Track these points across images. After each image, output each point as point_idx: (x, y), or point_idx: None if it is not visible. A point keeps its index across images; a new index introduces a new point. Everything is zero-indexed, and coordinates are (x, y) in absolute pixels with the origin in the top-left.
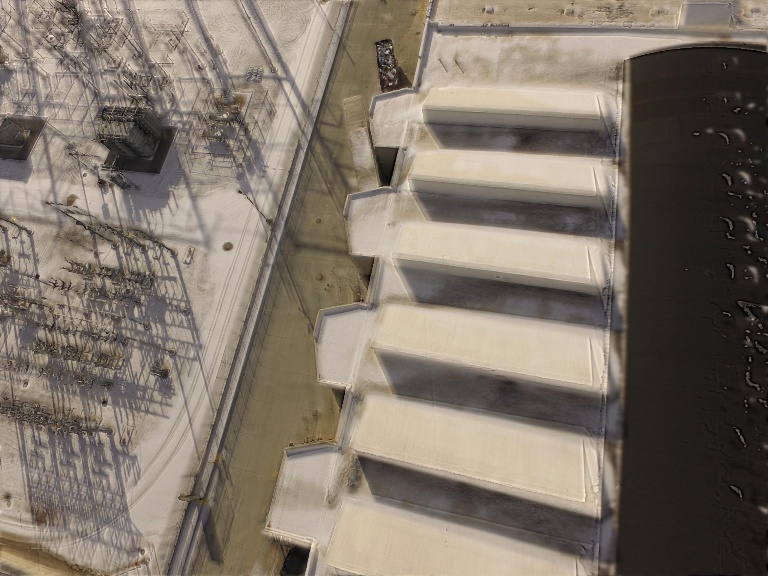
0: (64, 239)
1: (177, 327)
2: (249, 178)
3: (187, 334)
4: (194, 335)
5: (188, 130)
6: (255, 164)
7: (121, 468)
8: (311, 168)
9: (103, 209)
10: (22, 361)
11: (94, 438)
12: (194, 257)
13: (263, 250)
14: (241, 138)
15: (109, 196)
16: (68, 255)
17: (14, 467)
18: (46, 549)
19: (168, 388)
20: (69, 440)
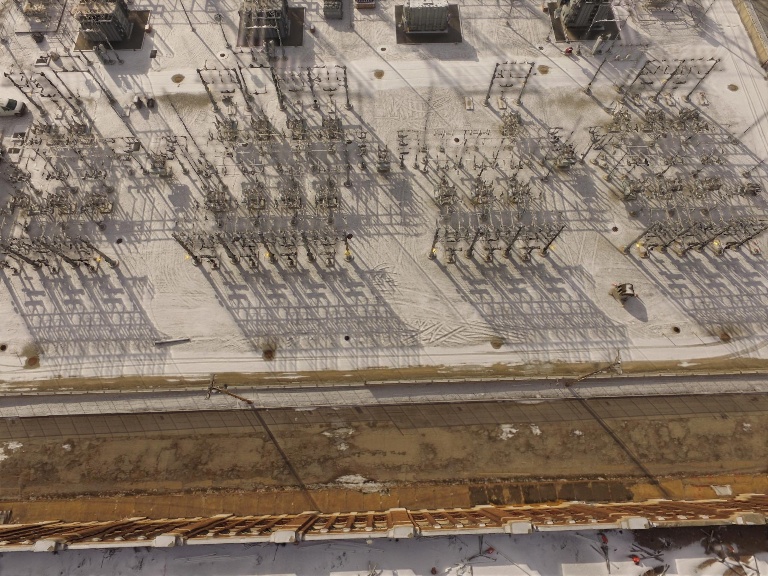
0: (561, 103)
1: (735, 155)
2: (711, 35)
3: (748, 158)
4: (755, 158)
5: (620, 4)
6: (708, 24)
7: (767, 273)
8: (766, 21)
9: (585, 73)
10: (596, 210)
11: (723, 255)
12: (708, 100)
13: (767, 86)
14: (678, 6)
15: (583, 62)
16: (576, 115)
17: (658, 299)
18: (746, 355)
19: (763, 202)
20: (699, 263)
